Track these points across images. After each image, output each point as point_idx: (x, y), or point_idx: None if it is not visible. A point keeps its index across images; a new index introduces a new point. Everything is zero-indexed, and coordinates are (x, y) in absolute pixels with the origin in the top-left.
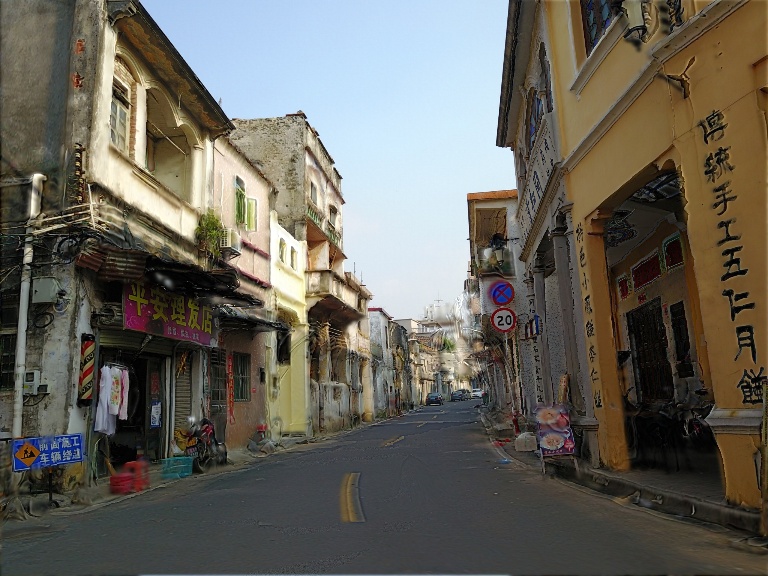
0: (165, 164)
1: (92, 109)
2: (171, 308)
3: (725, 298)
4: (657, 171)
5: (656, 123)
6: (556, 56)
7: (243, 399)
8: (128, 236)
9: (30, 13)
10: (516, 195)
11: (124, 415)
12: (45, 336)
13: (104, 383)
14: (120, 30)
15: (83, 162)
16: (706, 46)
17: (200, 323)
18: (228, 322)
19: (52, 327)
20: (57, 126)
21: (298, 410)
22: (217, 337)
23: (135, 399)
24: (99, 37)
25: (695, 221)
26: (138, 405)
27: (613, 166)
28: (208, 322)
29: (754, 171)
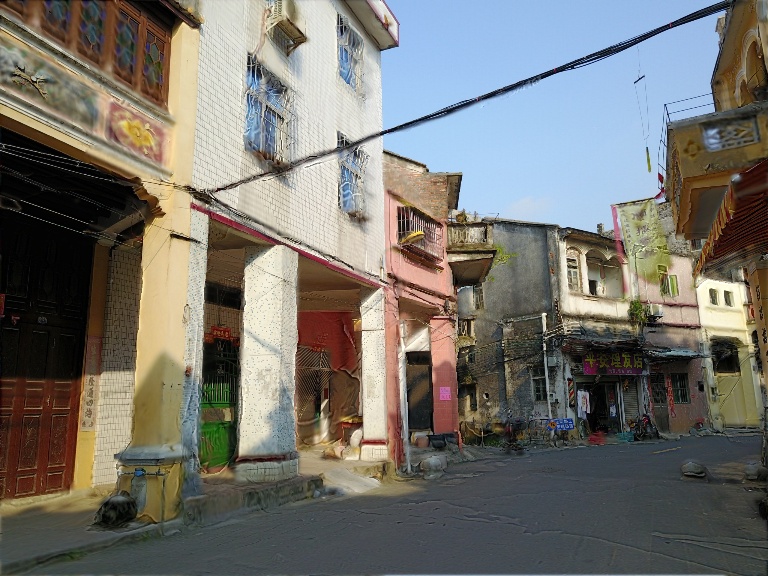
0: (610, 273)
1: (559, 283)
2: (611, 360)
3: None
4: None
5: None
6: None
7: (684, 402)
8: (583, 332)
9: (532, 243)
10: None
11: (589, 411)
12: (555, 379)
13: (579, 398)
14: (567, 239)
15: (558, 307)
16: None
17: (632, 364)
18: (655, 359)
19: (557, 375)
20: (548, 291)
21: (751, 409)
22: (648, 369)
23: (592, 405)
24: (557, 251)
25: None
26: (605, 406)
27: None
28: (639, 362)
29: None
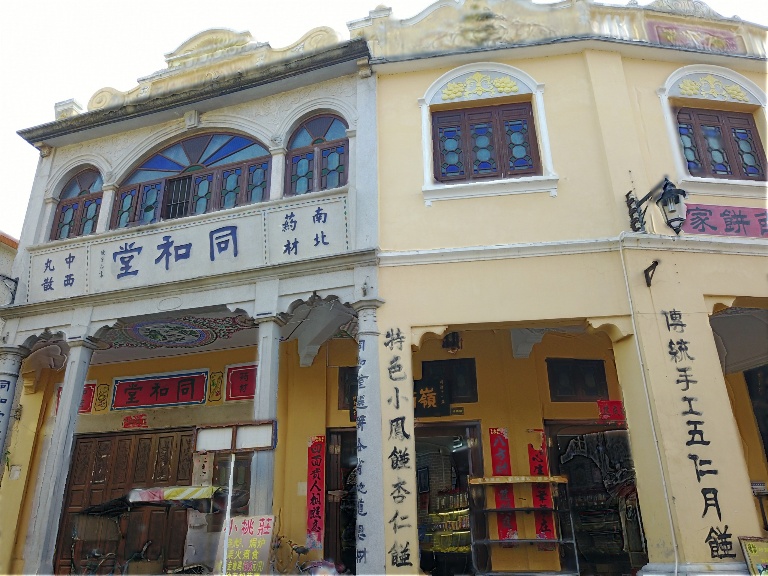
0: None
1: None
2: None
3: (691, 461)
4: (571, 325)
5: (593, 287)
6: (380, 142)
7: None
8: None
9: None
10: None
11: None
12: None
13: None
14: None
15: None
16: (664, 260)
17: None
18: None
19: None
20: None
21: None
22: None
23: None
24: None
25: (660, 388)
26: None
27: (502, 295)
28: None
29: (711, 368)
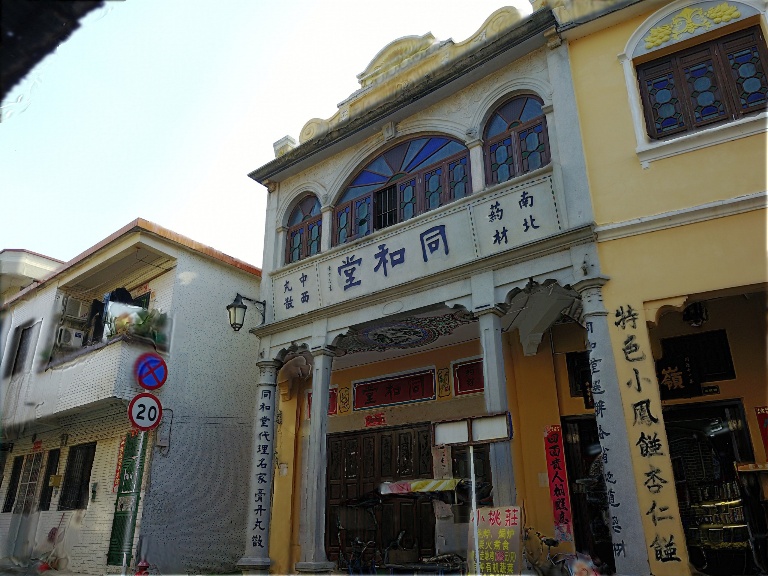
0: None
1: None
2: None
3: None
4: None
5: None
6: (580, 111)
7: None
8: None
9: None
10: (201, 249)
11: None
12: None
13: None
14: None
15: None
16: None
17: None
18: None
19: None
20: None
21: None
22: None
23: None
24: None
25: None
26: None
27: (752, 254)
28: None
29: None
